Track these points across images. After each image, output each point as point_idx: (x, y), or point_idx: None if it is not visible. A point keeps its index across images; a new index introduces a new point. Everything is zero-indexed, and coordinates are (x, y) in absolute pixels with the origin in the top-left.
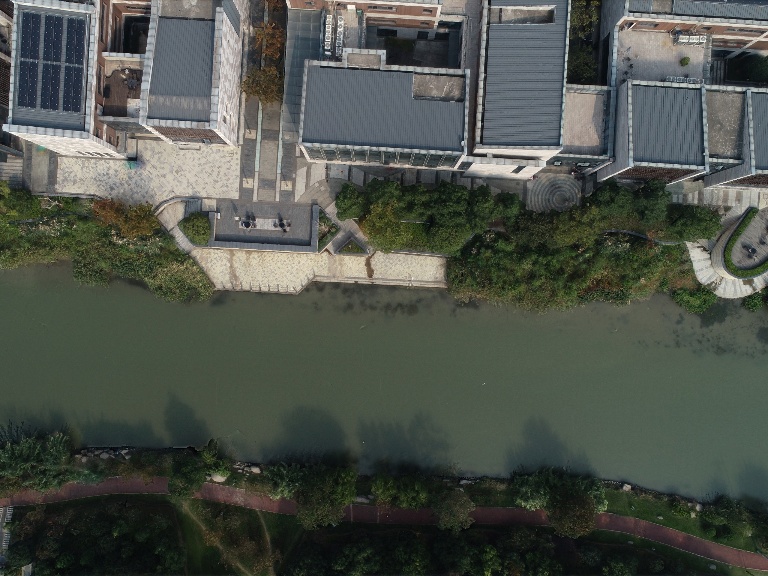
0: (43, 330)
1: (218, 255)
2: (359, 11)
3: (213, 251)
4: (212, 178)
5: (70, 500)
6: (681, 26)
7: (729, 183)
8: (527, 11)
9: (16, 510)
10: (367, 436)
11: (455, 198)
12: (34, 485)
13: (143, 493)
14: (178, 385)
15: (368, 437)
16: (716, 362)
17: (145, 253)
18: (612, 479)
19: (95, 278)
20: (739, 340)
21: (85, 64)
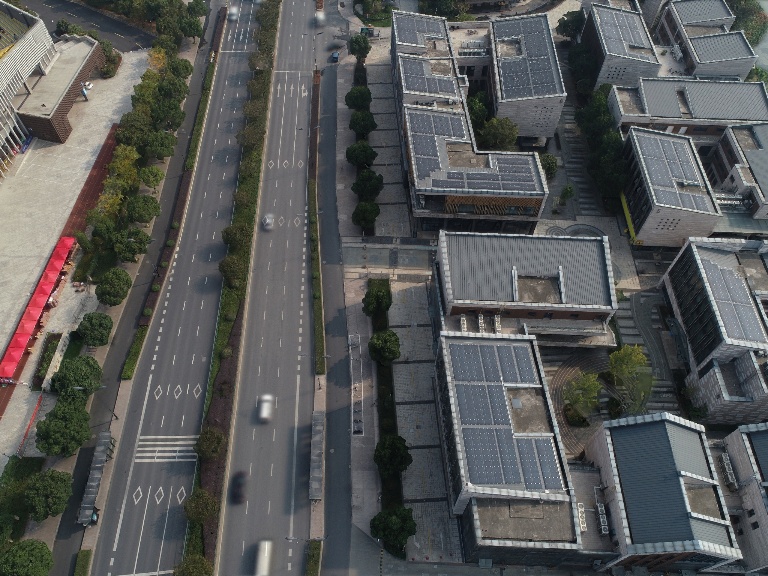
0: None
1: None
2: None
3: None
4: None
5: None
6: None
7: None
8: None
9: None
10: None
11: None
12: None
13: None
14: None
15: None
16: None
17: None
18: None
19: None
20: None
21: None
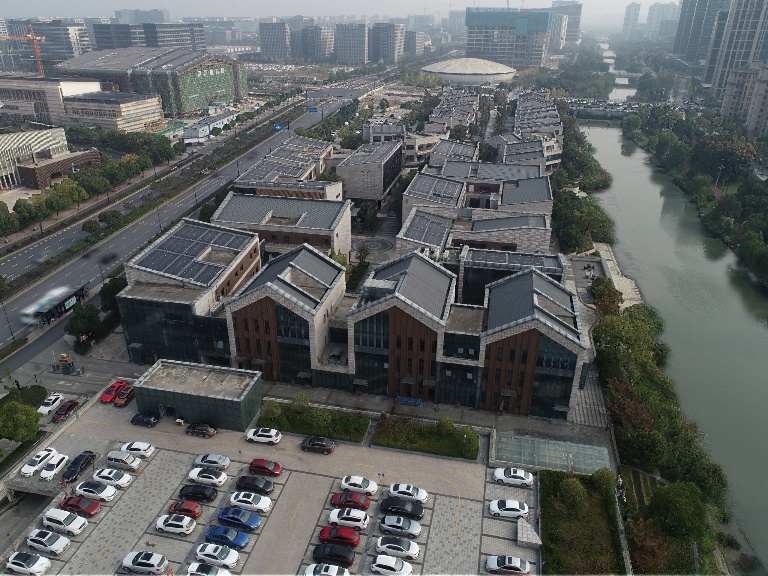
0: None
1: None
2: (463, 206)
3: None
4: None
5: None
6: None
7: None
8: None
9: None
10: (724, 270)
11: None
12: None
13: None
14: (737, 330)
15: (725, 270)
16: None
17: None
18: None
19: None
20: None
21: None
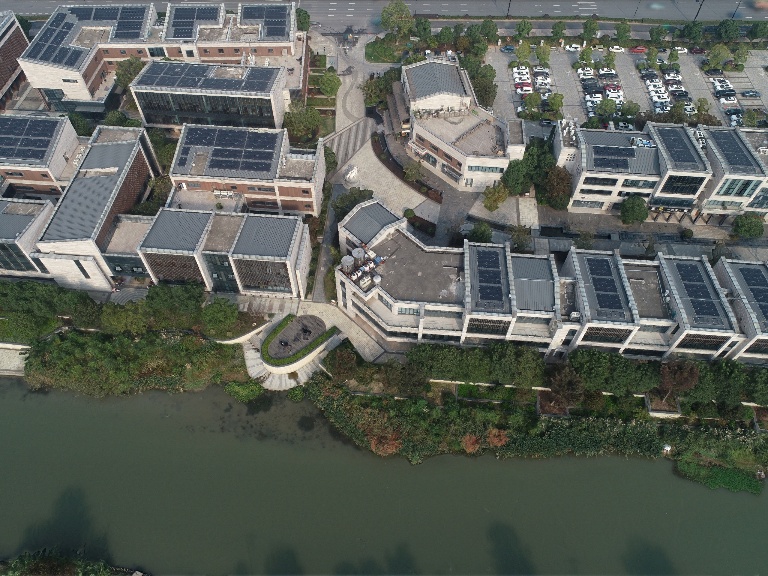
0: None
1: None
2: None
3: None
4: None
5: None
6: (216, 186)
7: (256, 287)
8: (104, 172)
9: None
10: None
11: (26, 287)
12: None
13: None
14: None
15: None
16: (256, 447)
17: None
18: (126, 567)
19: None
20: (281, 427)
21: None
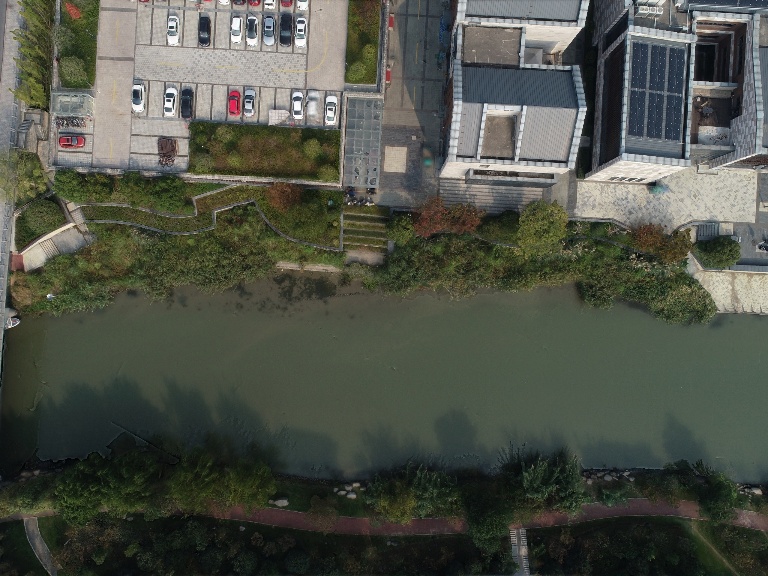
0: (545, 353)
1: (720, 278)
2: None
3: (715, 274)
4: (729, 202)
5: (581, 522)
6: None
7: None
8: None
9: (528, 533)
10: None
11: None
12: (564, 508)
13: (651, 515)
14: (677, 407)
15: None
16: None
17: (655, 276)
18: None
19: (609, 301)
20: None
21: (683, 93)
